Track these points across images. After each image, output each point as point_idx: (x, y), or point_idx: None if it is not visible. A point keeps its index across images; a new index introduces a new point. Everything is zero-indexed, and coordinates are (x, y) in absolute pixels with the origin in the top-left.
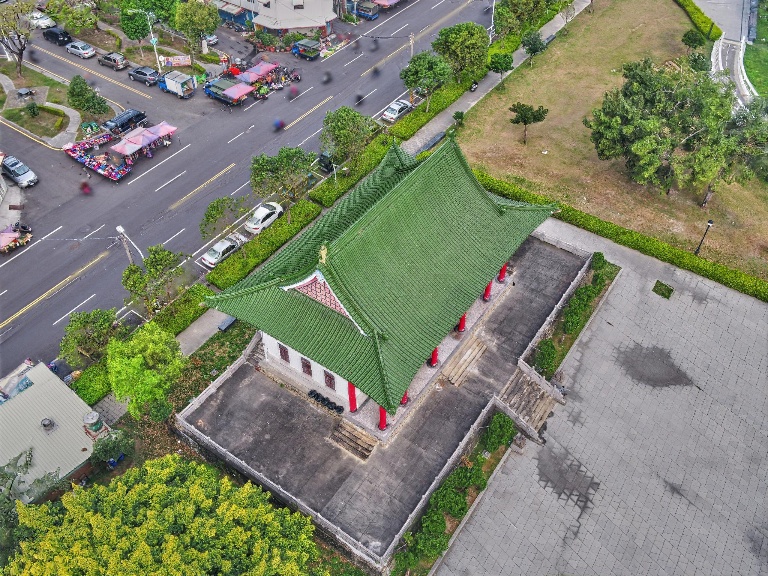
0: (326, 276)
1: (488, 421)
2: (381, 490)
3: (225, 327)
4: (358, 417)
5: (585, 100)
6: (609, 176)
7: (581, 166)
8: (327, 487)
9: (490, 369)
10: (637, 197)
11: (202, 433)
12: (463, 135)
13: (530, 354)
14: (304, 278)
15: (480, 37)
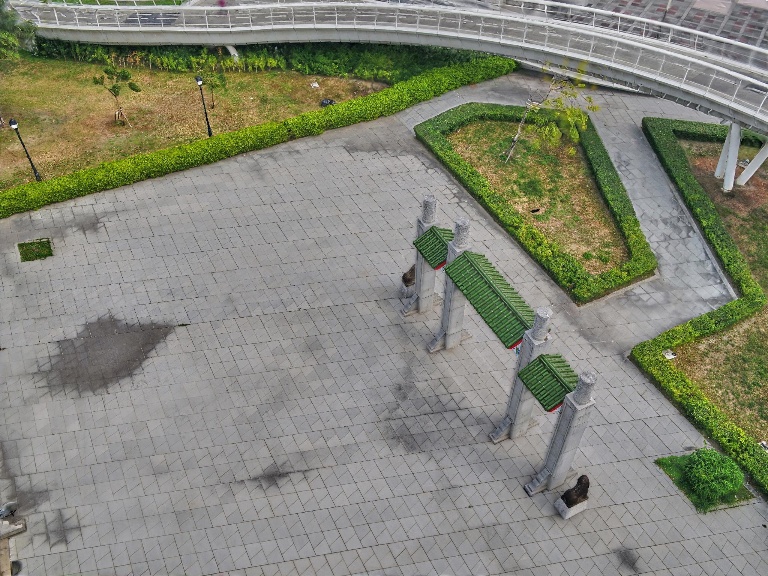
0: None
1: None
2: None
3: None
4: None
5: None
6: None
7: None
8: None
9: None
10: None
11: None
12: None
13: None
14: None
15: None
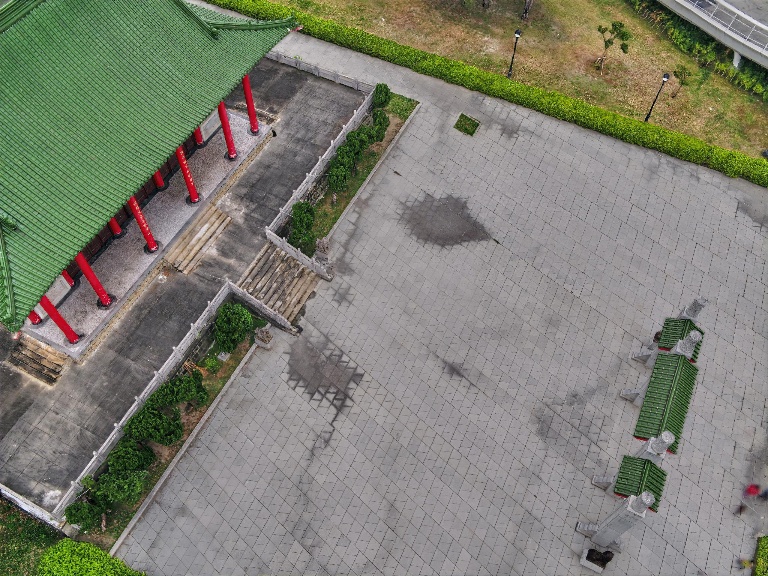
0: None
1: None
2: (69, 421)
3: None
4: (42, 330)
5: None
6: None
7: None
8: None
9: (232, 247)
10: (447, 12)
11: None
12: None
13: (286, 222)
14: None
15: None
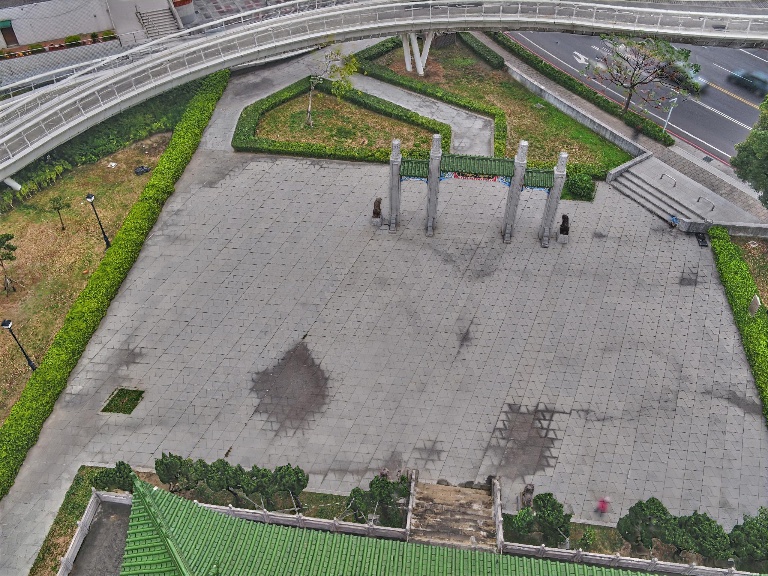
0: None
1: None
2: None
3: None
4: None
5: None
6: None
7: None
8: None
9: None
10: None
11: None
12: None
13: None
14: None
15: None
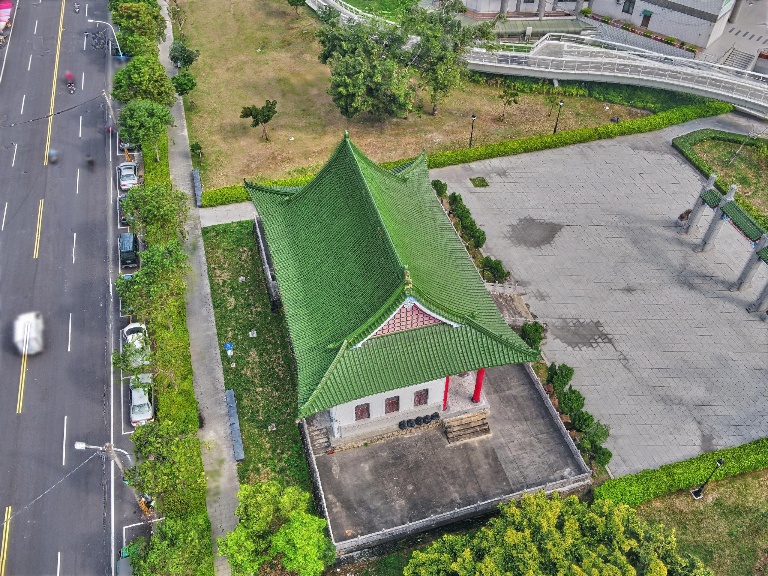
0: (417, 297)
1: None
2: (524, 439)
3: (243, 454)
4: (453, 409)
5: (268, 83)
6: (356, 129)
7: (329, 133)
8: (494, 473)
9: None
10: (391, 133)
11: None
12: (212, 163)
13: None
14: (388, 317)
15: (159, 67)
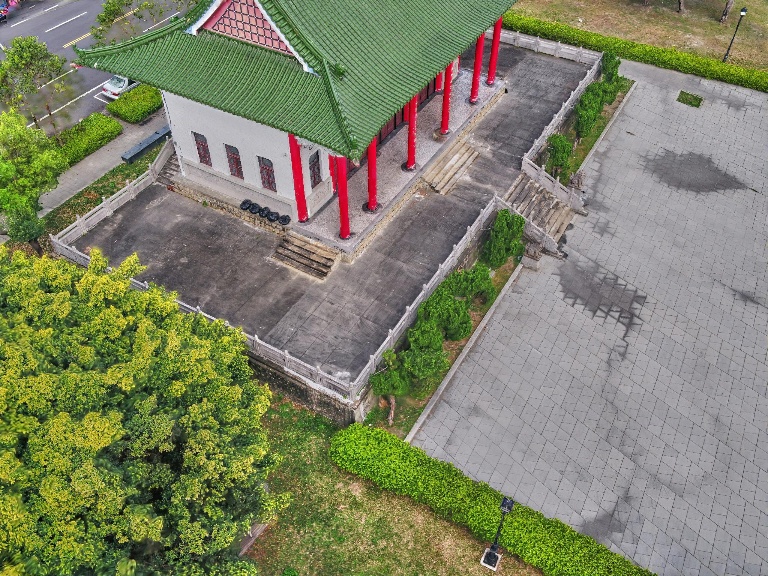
0: None
1: (488, 233)
2: (347, 311)
3: (130, 156)
4: (310, 227)
5: None
6: None
7: None
8: (269, 312)
9: (486, 175)
10: (643, 17)
11: (88, 257)
12: None
13: (536, 158)
14: None
15: None
